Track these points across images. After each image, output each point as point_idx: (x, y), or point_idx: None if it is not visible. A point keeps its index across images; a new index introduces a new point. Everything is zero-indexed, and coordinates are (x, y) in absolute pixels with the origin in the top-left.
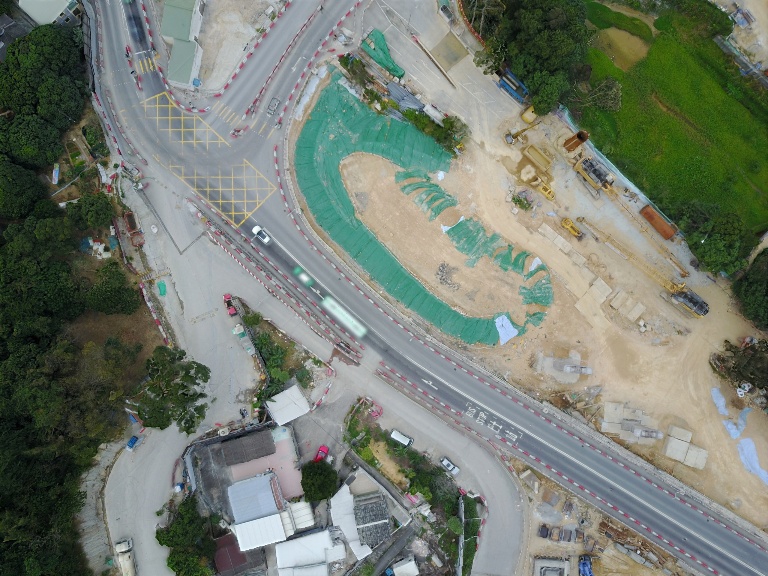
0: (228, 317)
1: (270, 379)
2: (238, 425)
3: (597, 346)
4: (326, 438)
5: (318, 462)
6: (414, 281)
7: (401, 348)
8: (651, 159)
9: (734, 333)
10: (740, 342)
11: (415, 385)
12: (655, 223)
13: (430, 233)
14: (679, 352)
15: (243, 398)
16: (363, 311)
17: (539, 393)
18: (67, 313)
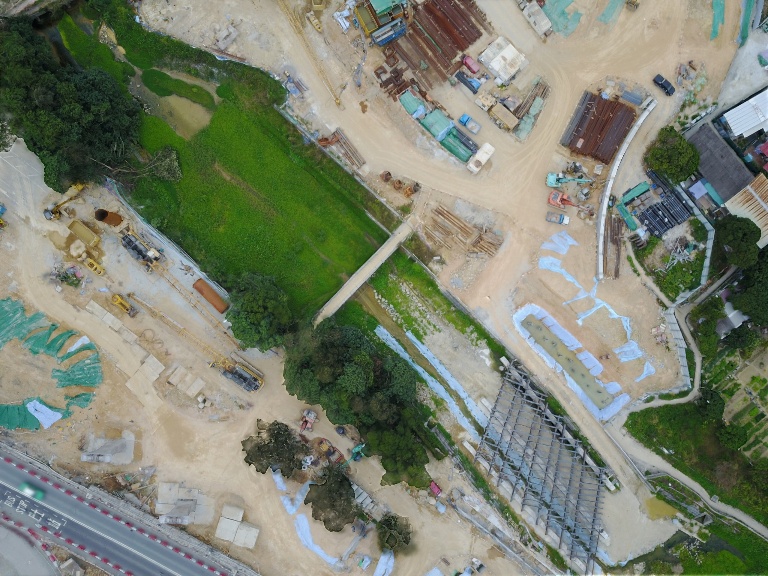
0: None
1: None
2: None
3: (149, 425)
4: None
5: None
6: None
7: None
8: (214, 229)
9: (298, 405)
10: (301, 415)
11: None
12: (206, 297)
13: None
14: (240, 427)
15: None
16: None
17: (89, 477)
18: None
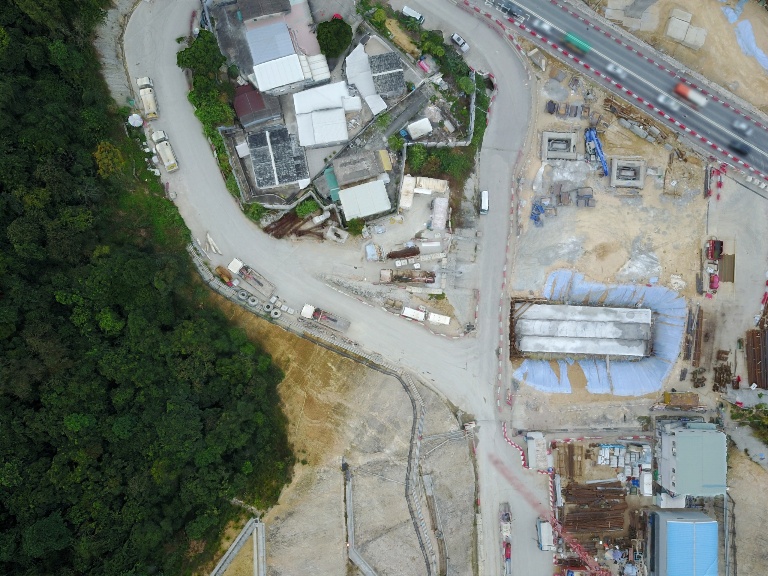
0: None
1: None
2: None
3: None
4: (339, 9)
5: (333, 19)
6: None
7: None
8: None
9: None
10: None
11: None
12: None
13: None
14: None
15: None
16: None
17: None
18: None
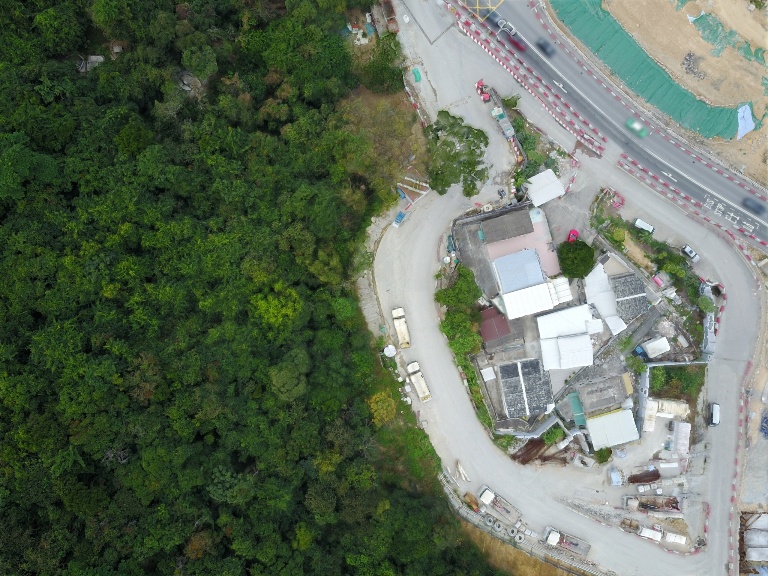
0: (481, 104)
1: (527, 161)
2: (496, 206)
3: None
4: (574, 224)
5: (575, 241)
6: (660, 71)
7: (641, 141)
8: None
9: None
10: None
11: (656, 176)
12: None
13: (677, 23)
14: None
15: (499, 180)
16: (604, 105)
17: None
18: (345, 84)
